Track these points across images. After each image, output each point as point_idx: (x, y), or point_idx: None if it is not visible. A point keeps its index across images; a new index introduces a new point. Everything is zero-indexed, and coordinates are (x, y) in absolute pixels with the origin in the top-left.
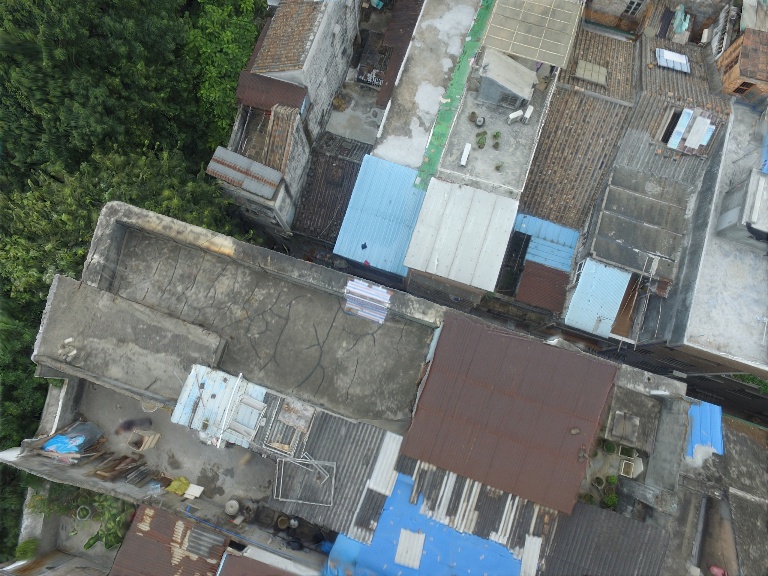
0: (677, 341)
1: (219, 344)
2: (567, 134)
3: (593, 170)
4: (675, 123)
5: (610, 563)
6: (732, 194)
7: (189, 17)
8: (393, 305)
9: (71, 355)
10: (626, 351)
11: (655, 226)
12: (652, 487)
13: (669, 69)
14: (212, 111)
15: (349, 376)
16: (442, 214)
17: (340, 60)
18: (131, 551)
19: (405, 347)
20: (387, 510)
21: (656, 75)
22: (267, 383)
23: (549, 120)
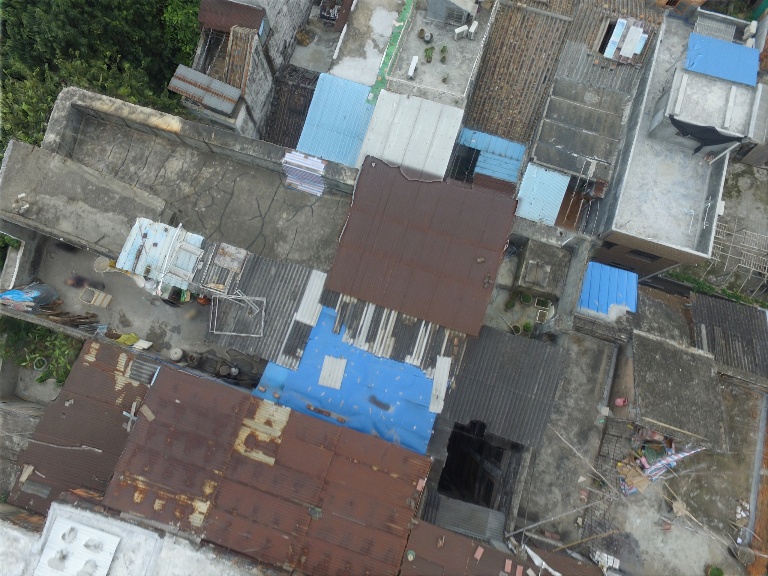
0: (607, 230)
1: (165, 208)
2: (512, 50)
3: (537, 84)
4: (611, 34)
5: (513, 380)
6: (662, 97)
7: None
8: (327, 173)
9: (24, 208)
10: None
11: (593, 132)
12: None
13: None
14: (176, 38)
15: (288, 243)
16: (391, 123)
17: None
18: (78, 378)
19: (341, 217)
20: (312, 340)
21: None
22: None
23: (494, 37)
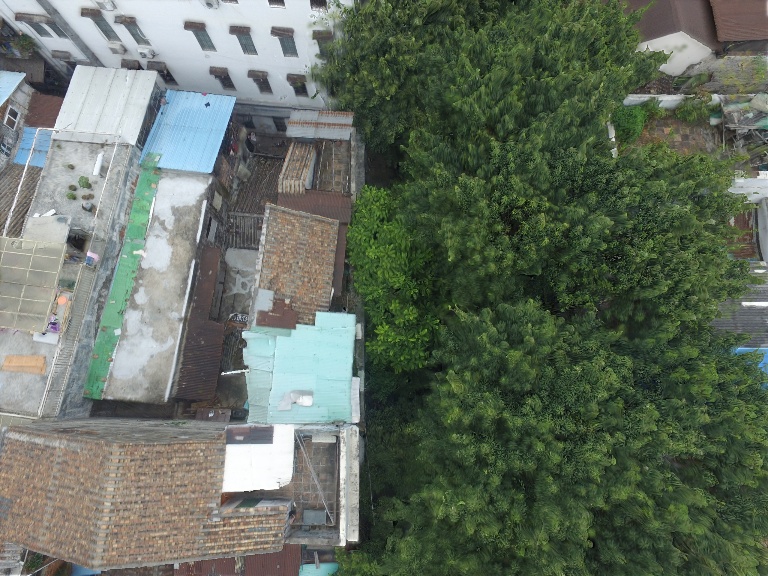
0: None
1: None
2: None
3: None
4: None
5: None
6: None
7: (400, 230)
8: None
9: None
10: None
11: None
12: None
13: None
14: None
15: None
16: (123, 116)
17: None
18: None
19: None
20: None
21: None
22: None
23: None
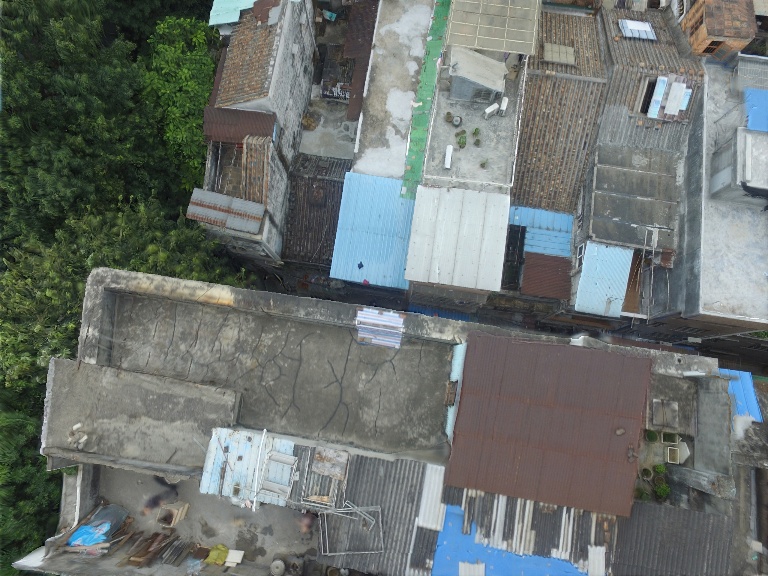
0: (692, 311)
1: (235, 400)
2: (545, 120)
3: (577, 151)
4: (651, 92)
5: (678, 560)
6: (720, 155)
7: None
8: (408, 329)
9: (82, 442)
10: (639, 326)
11: (648, 198)
12: (704, 472)
13: (635, 39)
14: (181, 152)
15: (374, 408)
16: (435, 221)
17: (302, 79)
18: None
19: (426, 368)
20: (441, 546)
21: (624, 47)
22: (291, 430)
23: (525, 108)
